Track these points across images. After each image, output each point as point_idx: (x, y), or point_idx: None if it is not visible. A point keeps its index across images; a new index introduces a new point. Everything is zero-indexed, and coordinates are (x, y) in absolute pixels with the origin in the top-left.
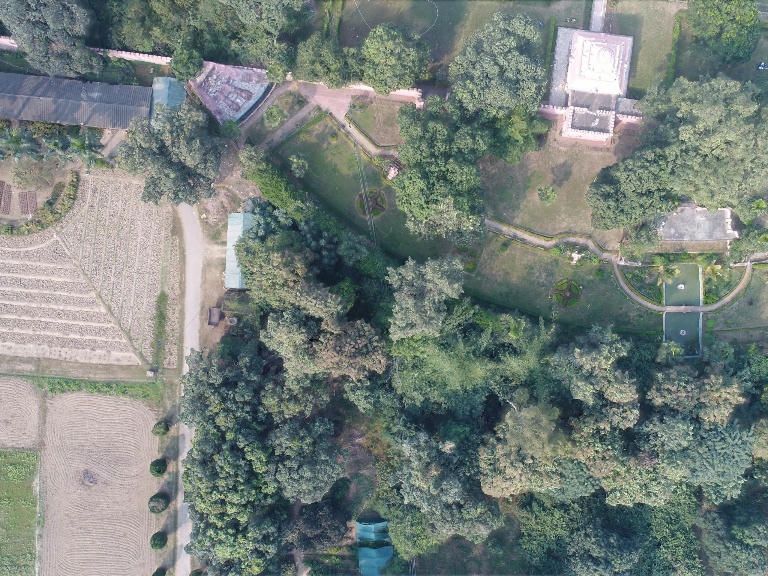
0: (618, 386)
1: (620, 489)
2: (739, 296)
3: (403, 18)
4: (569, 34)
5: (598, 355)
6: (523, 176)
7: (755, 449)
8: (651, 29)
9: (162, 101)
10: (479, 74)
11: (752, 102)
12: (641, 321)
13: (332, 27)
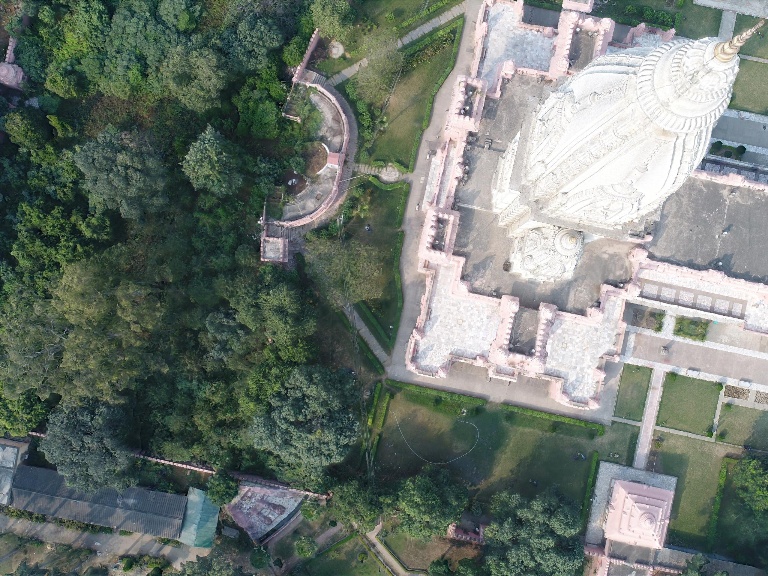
0: None
1: None
2: None
3: (443, 439)
4: (611, 469)
5: None
6: None
7: None
8: (696, 470)
9: (195, 514)
10: (514, 561)
11: None
12: None
13: (370, 469)
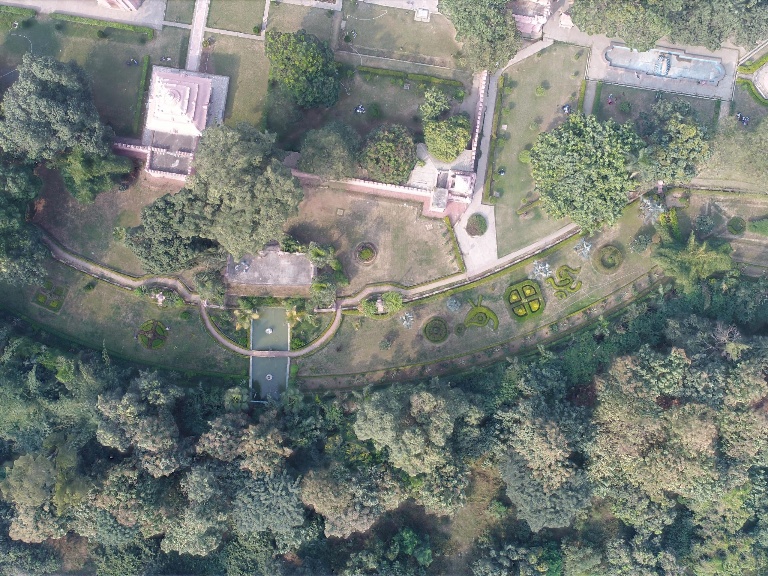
0: (139, 435)
1: (169, 536)
2: (326, 342)
3: None
4: None
5: (117, 403)
6: (113, 215)
7: (304, 500)
8: (248, 69)
9: None
10: (9, 116)
11: (249, 153)
12: (226, 365)
13: None
